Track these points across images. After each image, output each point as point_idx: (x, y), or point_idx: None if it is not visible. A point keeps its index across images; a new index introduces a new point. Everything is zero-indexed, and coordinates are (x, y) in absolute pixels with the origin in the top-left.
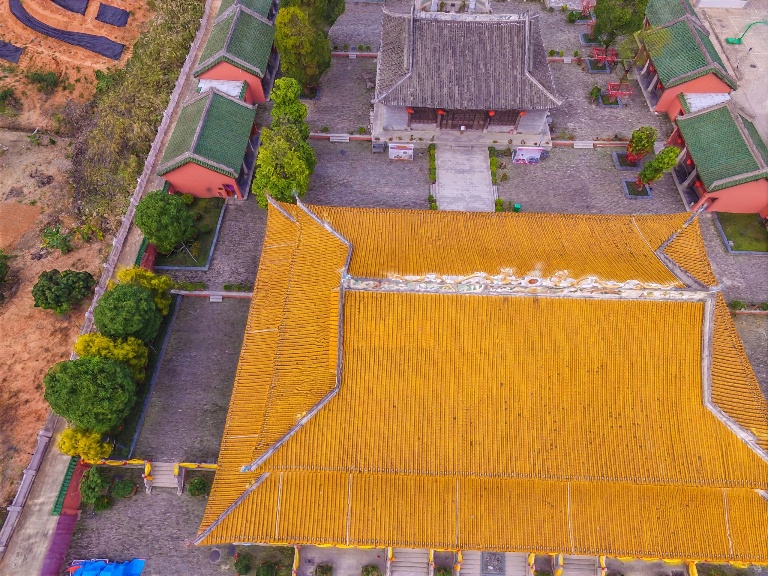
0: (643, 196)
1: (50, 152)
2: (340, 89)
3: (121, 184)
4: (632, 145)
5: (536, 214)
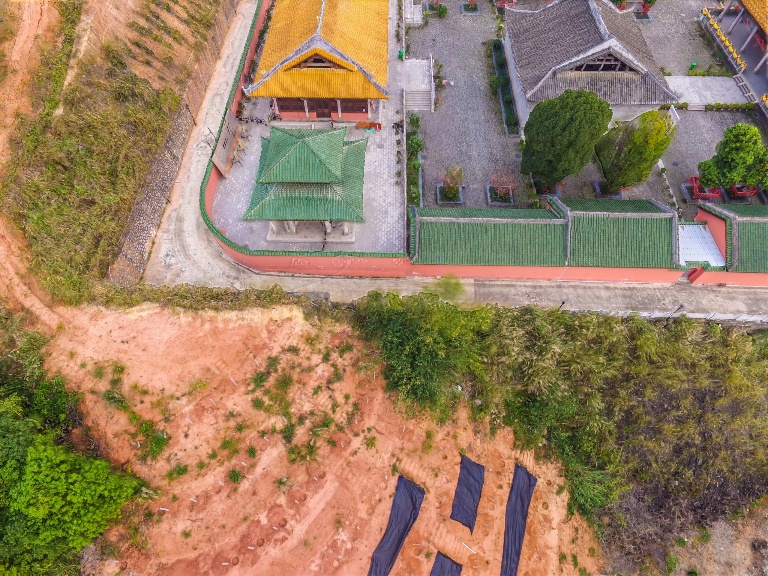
0: (648, 14)
1: (709, 573)
2: (589, 166)
3: (765, 398)
4: (620, 2)
5: (765, 26)
